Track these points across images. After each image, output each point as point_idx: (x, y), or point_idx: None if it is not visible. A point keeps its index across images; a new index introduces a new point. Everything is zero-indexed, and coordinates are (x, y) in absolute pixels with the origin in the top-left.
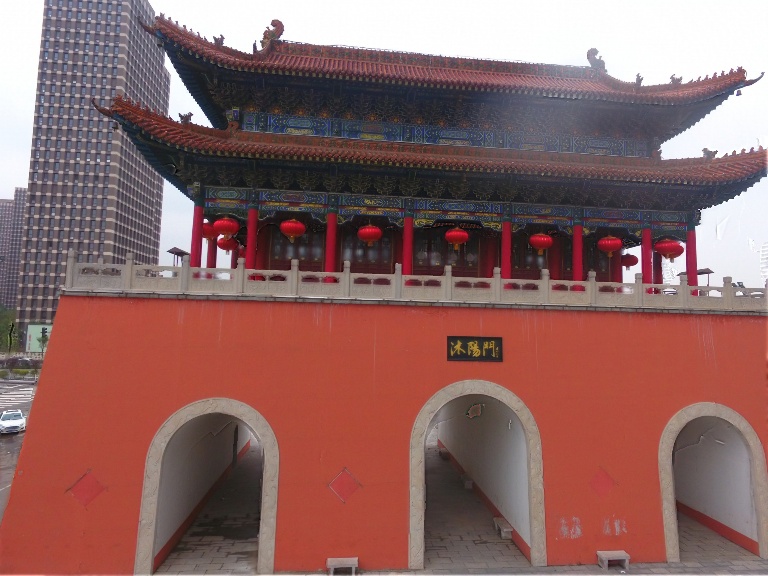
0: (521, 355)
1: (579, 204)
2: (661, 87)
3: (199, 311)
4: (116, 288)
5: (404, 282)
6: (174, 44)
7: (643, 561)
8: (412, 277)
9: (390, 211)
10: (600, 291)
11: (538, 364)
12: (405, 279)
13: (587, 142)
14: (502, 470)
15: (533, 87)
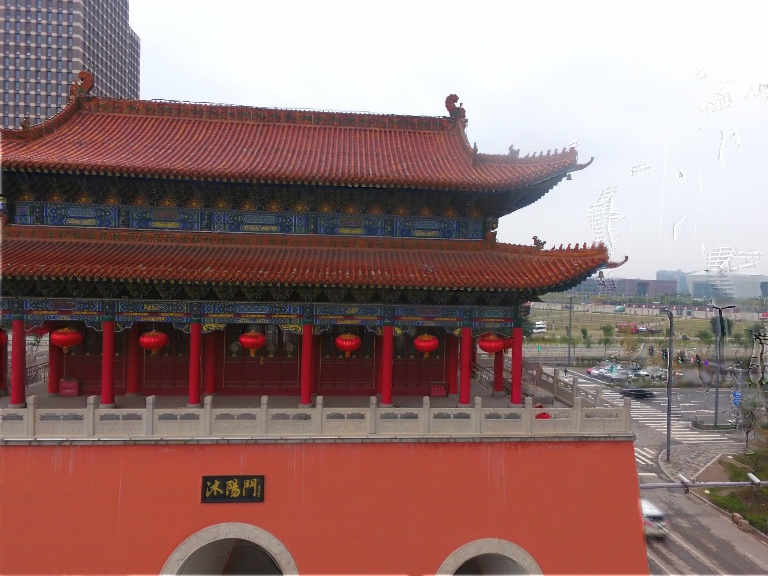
0: (285, 494)
1: (390, 302)
2: (500, 158)
3: None
4: None
5: (157, 417)
6: None
7: None
8: (166, 411)
9: (174, 316)
10: (382, 418)
11: (303, 503)
12: (158, 414)
13: (413, 223)
14: None
15: (328, 178)
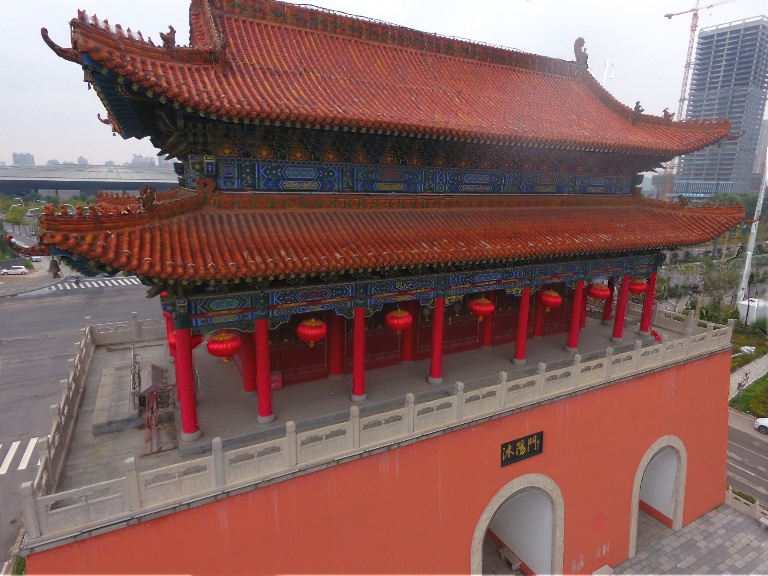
0: (555, 441)
1: (585, 258)
2: (653, 119)
3: (246, 504)
4: (117, 513)
5: (464, 401)
6: (117, 78)
7: (616, 565)
8: (472, 394)
9: (422, 293)
10: (612, 364)
11: (567, 446)
12: (466, 398)
13: (589, 180)
14: (507, 511)
15: (576, 142)
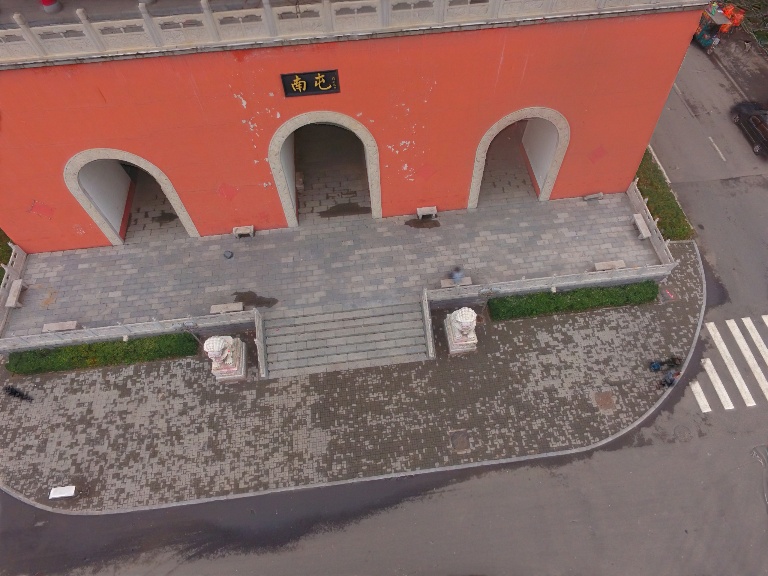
0: None
1: None
2: None
3: None
4: None
5: None
6: None
7: None
8: None
9: None
10: None
11: None
12: None
13: None
14: None
15: None
